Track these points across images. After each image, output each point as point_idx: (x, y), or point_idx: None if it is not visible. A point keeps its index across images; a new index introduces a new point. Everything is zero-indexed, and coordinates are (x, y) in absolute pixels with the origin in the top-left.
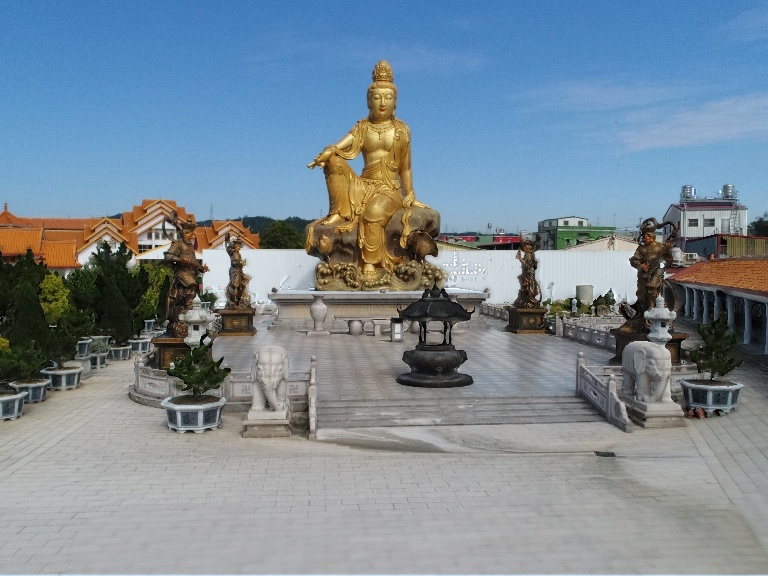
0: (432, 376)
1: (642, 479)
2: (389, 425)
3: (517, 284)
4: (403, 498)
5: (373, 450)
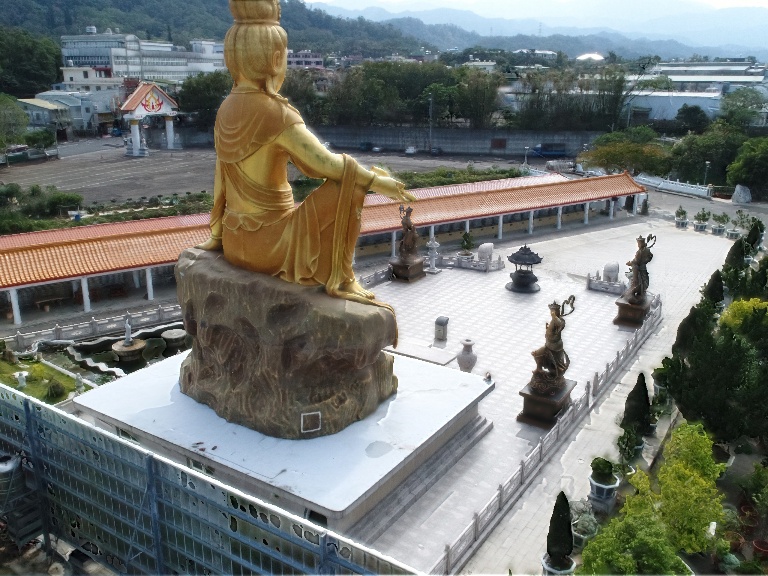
0: None
1: None
2: None
3: None
4: (597, 266)
5: None
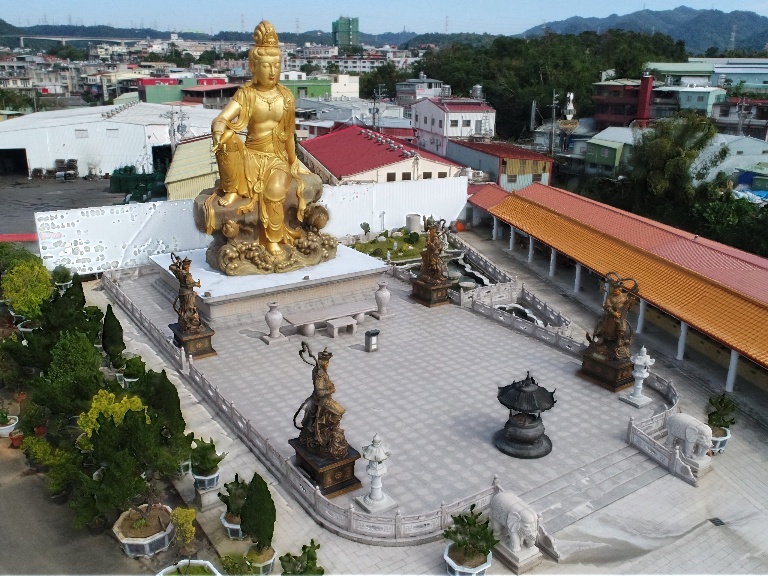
0: (532, 446)
1: None
2: (573, 522)
3: (354, 216)
4: None
5: (612, 564)
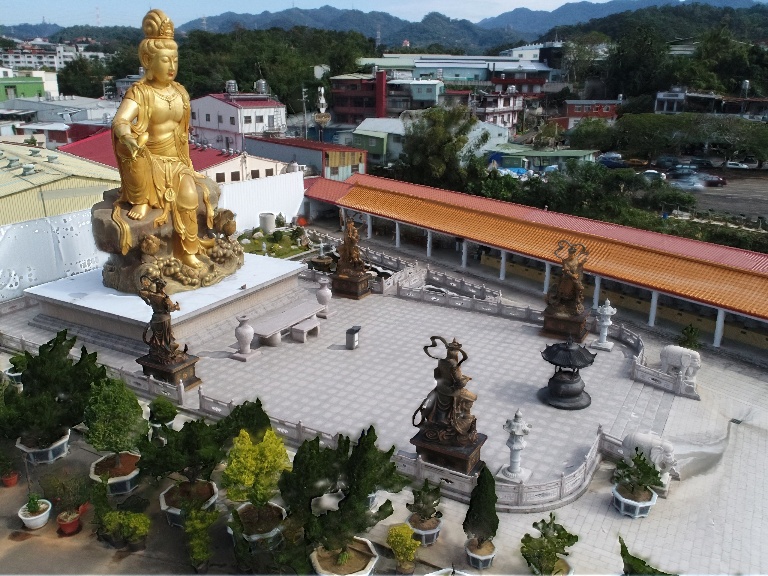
0: (579, 398)
1: None
2: None
3: None
4: None
5: None
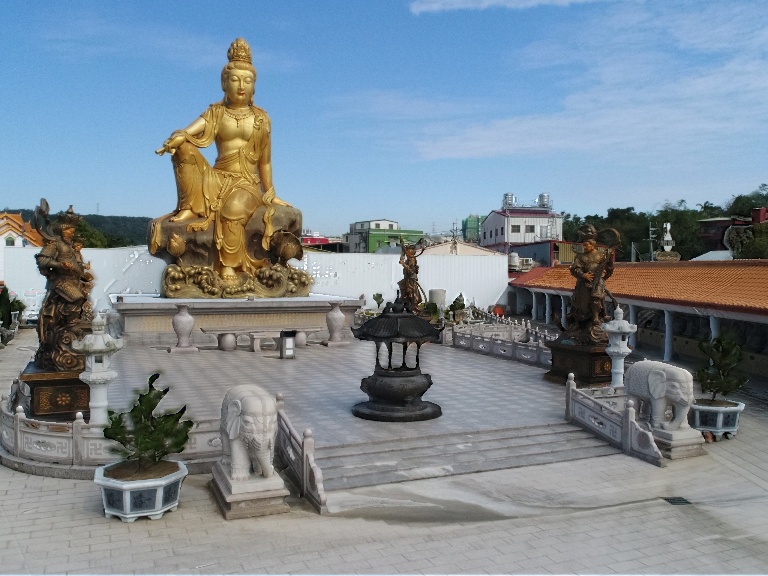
0: (400, 407)
1: (765, 536)
2: (399, 480)
3: (369, 288)
4: None
5: (420, 524)
